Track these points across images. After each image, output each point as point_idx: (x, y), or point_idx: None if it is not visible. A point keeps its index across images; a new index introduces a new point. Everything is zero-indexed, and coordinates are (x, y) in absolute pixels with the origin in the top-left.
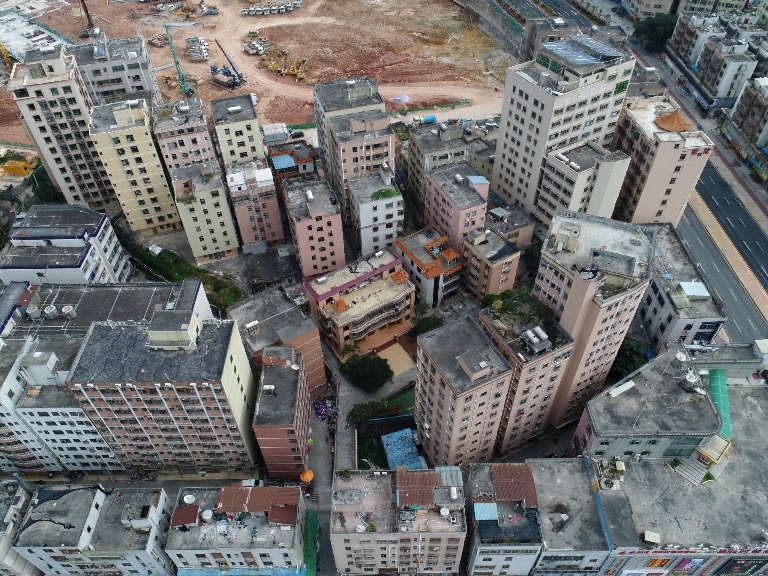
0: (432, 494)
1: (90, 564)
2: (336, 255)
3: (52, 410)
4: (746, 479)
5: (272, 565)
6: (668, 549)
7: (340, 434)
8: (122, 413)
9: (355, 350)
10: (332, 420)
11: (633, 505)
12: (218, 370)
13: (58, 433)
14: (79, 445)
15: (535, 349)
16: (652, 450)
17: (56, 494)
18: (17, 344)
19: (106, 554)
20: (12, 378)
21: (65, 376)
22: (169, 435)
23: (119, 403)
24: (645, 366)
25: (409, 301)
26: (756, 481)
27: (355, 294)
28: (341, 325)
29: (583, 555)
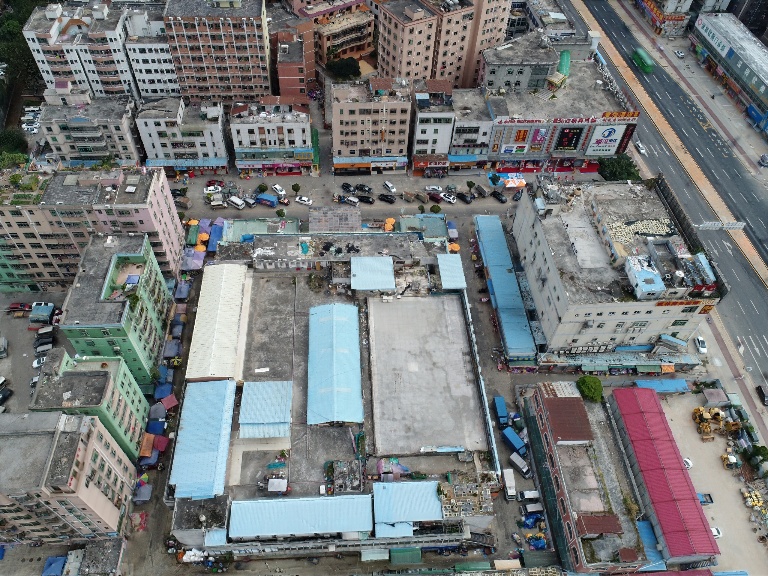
0: (391, 85)
1: (180, 142)
2: (317, 1)
3: (149, 46)
4: (575, 98)
5: (294, 145)
6: (526, 119)
7: (327, 103)
8: (194, 50)
9: (335, 53)
10: (321, 100)
11: (509, 108)
12: (257, 15)
13: (148, 73)
14: (160, 87)
15: (451, 8)
16: (521, 80)
17: (155, 100)
18: (117, 13)
19: (193, 129)
20: (120, 26)
21: (155, 27)
22: (221, 75)
23: (194, 38)
24: (519, 38)
25: (370, 29)
26: (581, 99)
27: (333, 20)
28: (325, 34)
29: (478, 126)
